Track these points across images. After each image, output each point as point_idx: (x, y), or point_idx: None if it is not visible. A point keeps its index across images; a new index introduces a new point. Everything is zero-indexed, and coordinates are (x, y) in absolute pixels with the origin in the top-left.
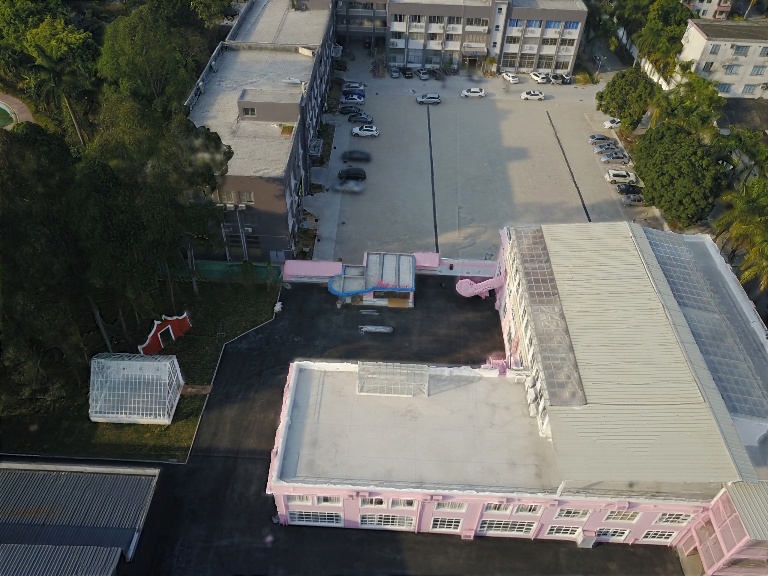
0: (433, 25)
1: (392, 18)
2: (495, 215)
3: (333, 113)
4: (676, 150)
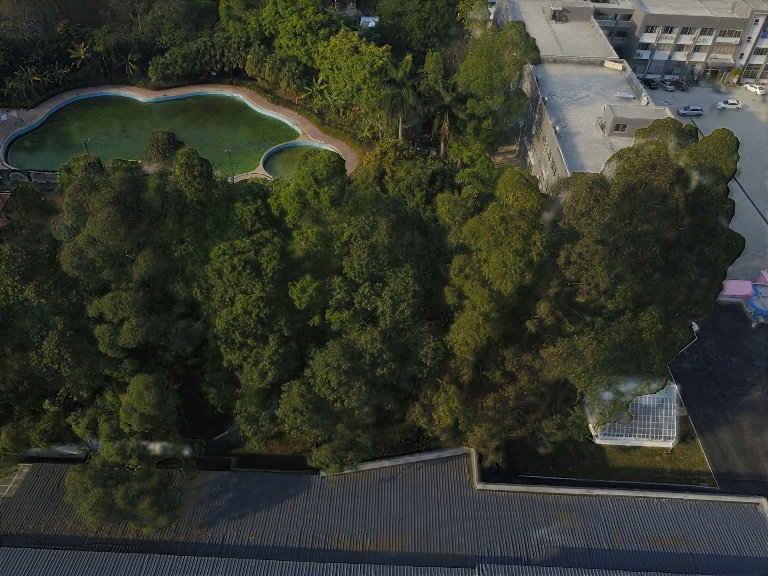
0: (683, 36)
1: (643, 29)
2: None
3: None
4: None
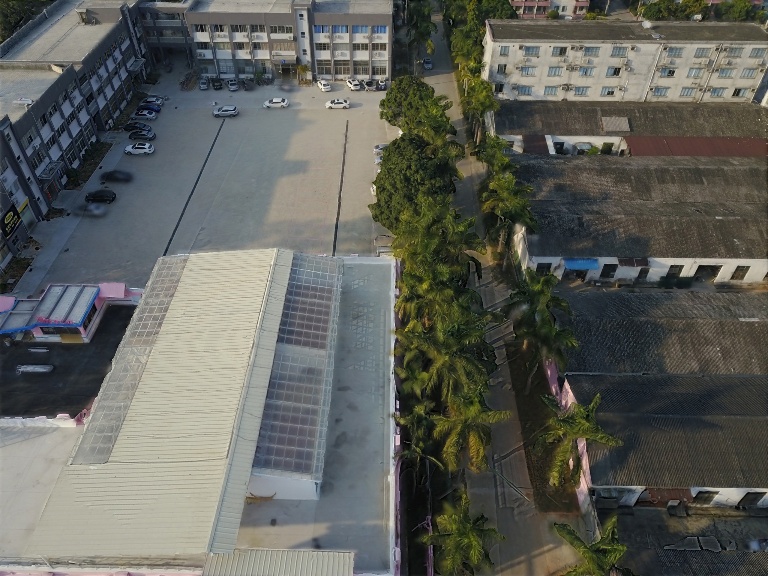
0: (237, 34)
1: (193, 28)
2: (235, 236)
3: (117, 130)
4: (398, 163)
